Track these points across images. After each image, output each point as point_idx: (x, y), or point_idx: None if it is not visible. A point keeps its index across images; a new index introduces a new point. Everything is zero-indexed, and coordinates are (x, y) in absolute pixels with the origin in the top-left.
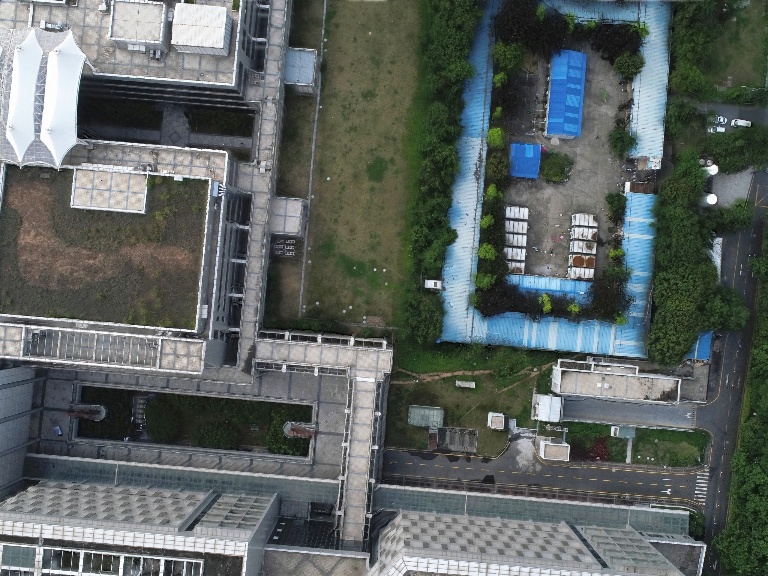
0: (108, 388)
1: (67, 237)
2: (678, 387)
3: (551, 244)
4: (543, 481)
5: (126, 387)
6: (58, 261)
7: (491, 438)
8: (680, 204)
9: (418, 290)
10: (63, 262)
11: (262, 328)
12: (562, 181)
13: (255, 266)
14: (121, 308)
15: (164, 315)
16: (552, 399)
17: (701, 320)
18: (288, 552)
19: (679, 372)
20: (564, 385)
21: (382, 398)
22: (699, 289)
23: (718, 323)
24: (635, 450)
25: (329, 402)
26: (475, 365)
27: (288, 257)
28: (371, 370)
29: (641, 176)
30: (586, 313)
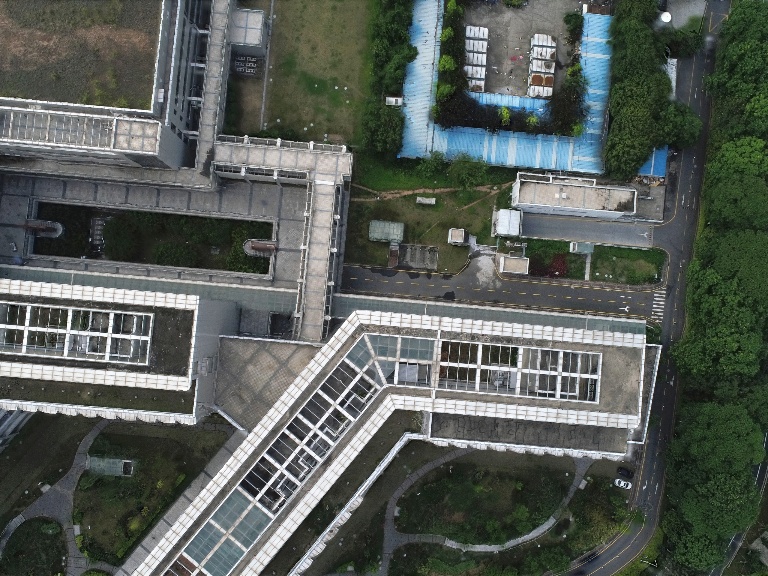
0: (65, 206)
1: (21, 18)
2: (634, 198)
3: (511, 66)
4: (503, 297)
5: (83, 203)
6: (11, 42)
7: (451, 255)
8: (635, 17)
9: (378, 102)
10: (17, 43)
11: (221, 133)
12: (521, 5)
13: (214, 70)
14: (75, 90)
15: (119, 97)
16: (511, 212)
17: (656, 128)
18: (244, 341)
19: (635, 185)
20: (523, 196)
21: (342, 205)
22: (653, 94)
23: (672, 134)
24: (593, 267)
25: (290, 219)
26: (436, 183)
27: (249, 75)
28: (330, 174)
29: (598, 1)
30: (544, 126)
